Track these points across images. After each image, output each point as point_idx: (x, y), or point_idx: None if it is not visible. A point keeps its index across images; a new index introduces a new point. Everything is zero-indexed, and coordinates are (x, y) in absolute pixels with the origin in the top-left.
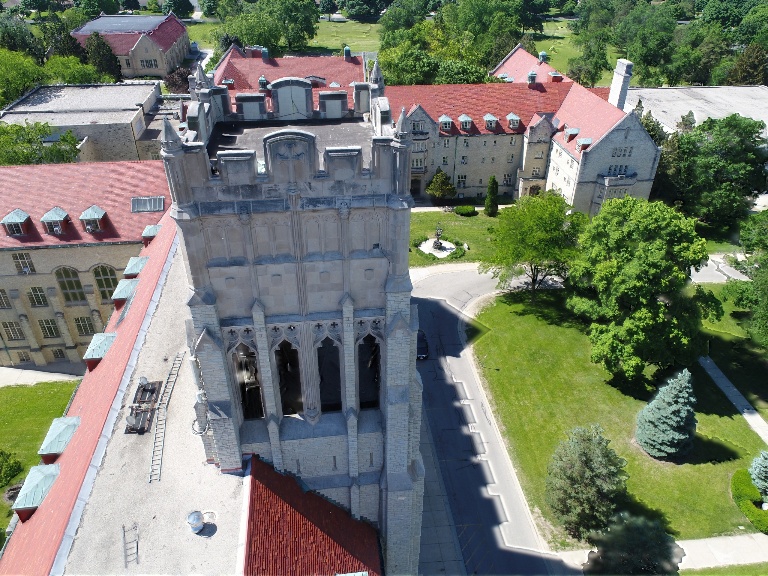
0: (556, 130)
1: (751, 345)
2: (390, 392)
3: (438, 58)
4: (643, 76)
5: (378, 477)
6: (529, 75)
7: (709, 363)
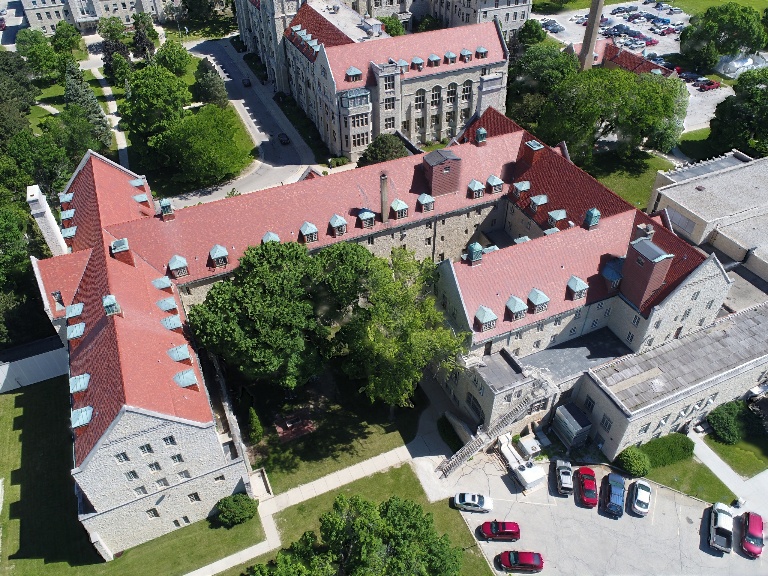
0: None
1: (105, 145)
2: None
3: (364, 574)
4: None
5: None
6: None
7: (123, 165)
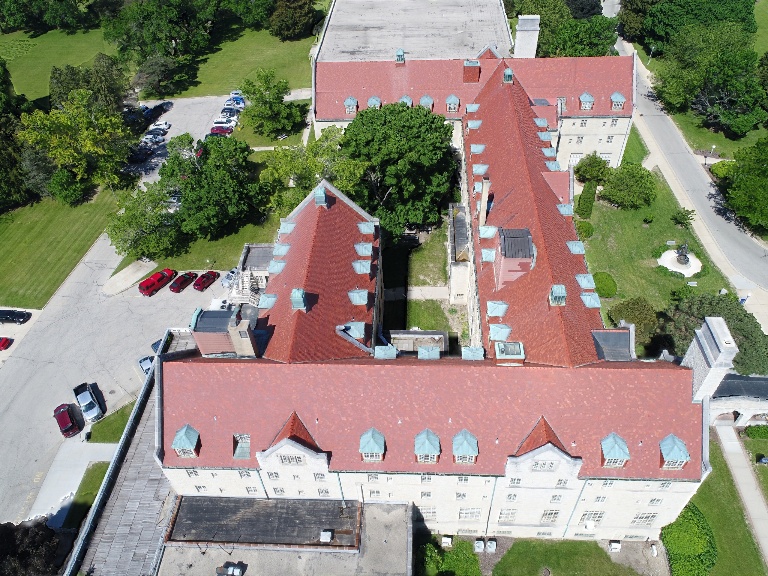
0: None
1: None
2: None
3: None
4: (186, 39)
5: None
6: (511, 74)
7: None
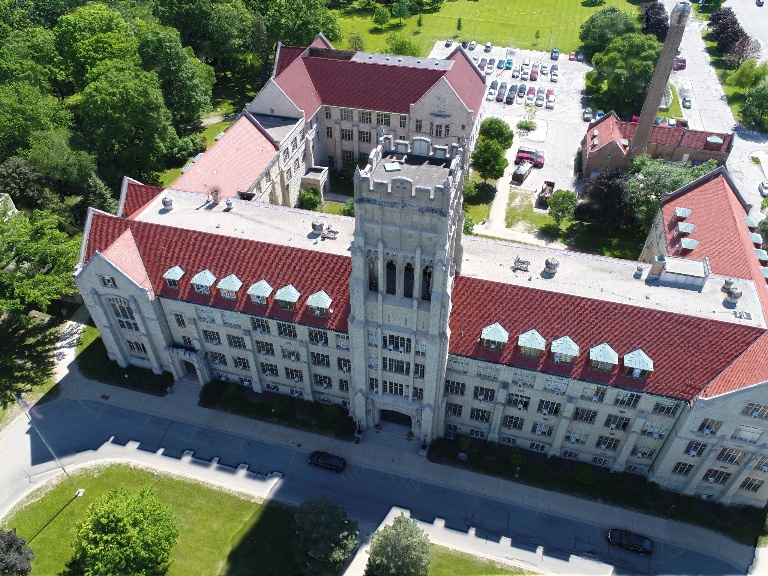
0: None
1: None
2: None
3: None
4: None
5: None
6: None
7: None
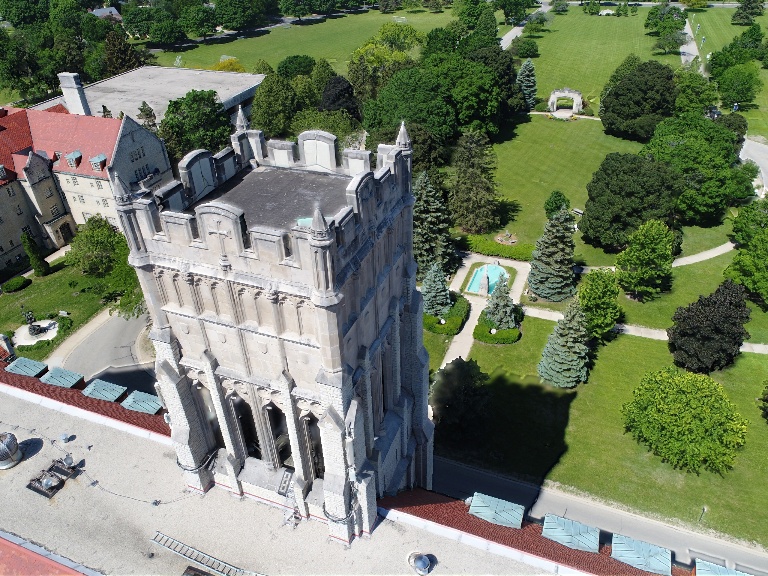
0: (50, 162)
1: None
2: (420, 358)
3: None
4: (22, 89)
5: (414, 440)
6: None
7: None
